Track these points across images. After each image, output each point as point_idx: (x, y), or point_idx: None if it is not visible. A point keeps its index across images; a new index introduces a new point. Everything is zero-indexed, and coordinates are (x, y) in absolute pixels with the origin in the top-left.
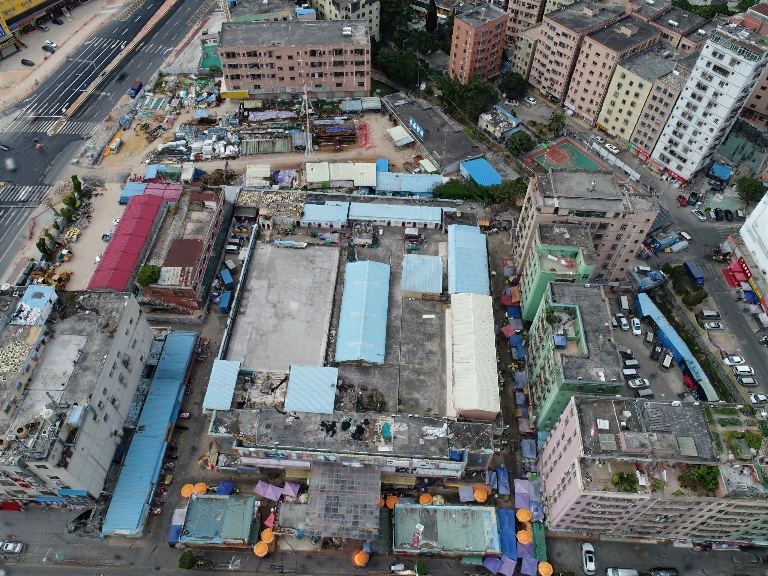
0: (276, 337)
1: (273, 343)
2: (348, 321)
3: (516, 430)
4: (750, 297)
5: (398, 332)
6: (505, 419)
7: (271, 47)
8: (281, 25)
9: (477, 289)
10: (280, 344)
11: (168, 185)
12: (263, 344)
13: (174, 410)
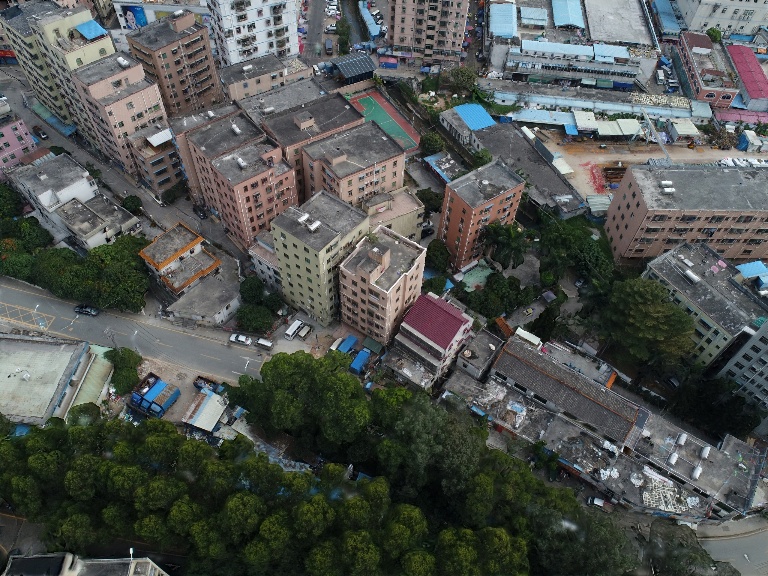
0: (615, 6)
1: (615, 4)
2: (576, 2)
3: (471, 1)
4: (302, 29)
5: (544, 5)
6: (475, 6)
7: (752, 167)
8: (766, 210)
9: (498, 6)
10: (611, 3)
11: (759, 120)
12: (621, 4)
13: (654, 5)
